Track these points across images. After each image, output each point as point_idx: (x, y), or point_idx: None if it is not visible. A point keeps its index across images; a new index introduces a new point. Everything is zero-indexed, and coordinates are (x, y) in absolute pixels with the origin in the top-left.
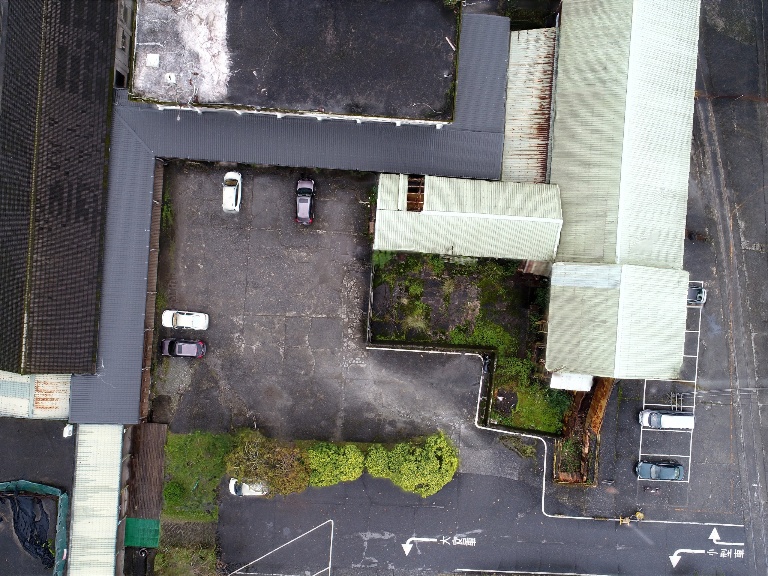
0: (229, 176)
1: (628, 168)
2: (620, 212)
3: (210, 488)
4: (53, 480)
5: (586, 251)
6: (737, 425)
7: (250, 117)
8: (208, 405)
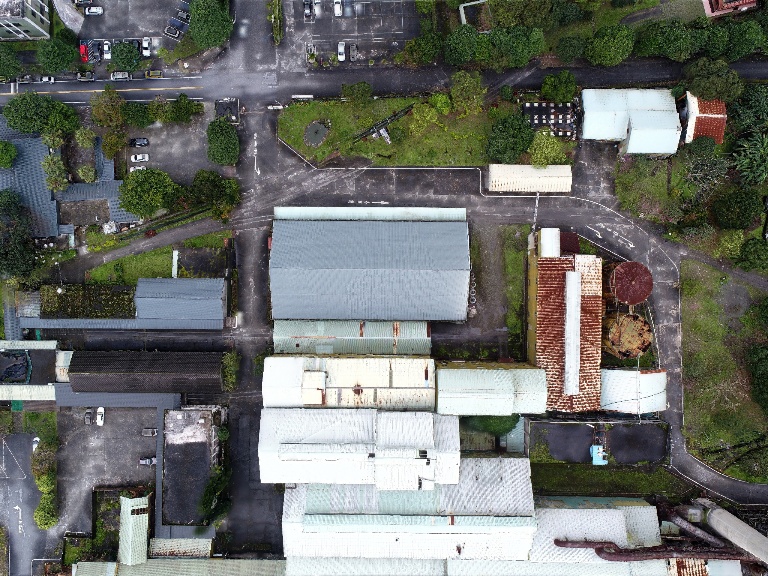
0: None
1: None
2: None
3: None
4: (33, 378)
5: (121, 574)
6: None
7: None
8: (69, 426)
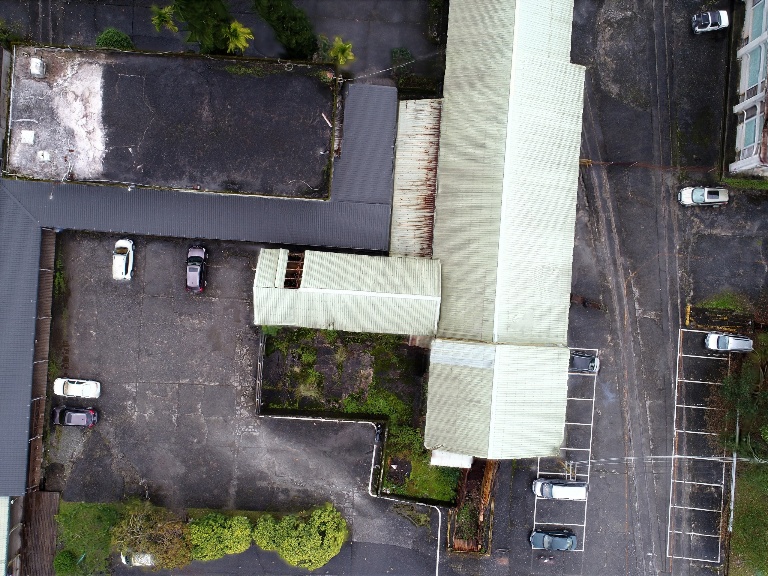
0: (120, 244)
1: (506, 245)
2: (497, 290)
3: (102, 557)
4: None
5: (466, 328)
6: (632, 494)
7: None
8: (101, 473)
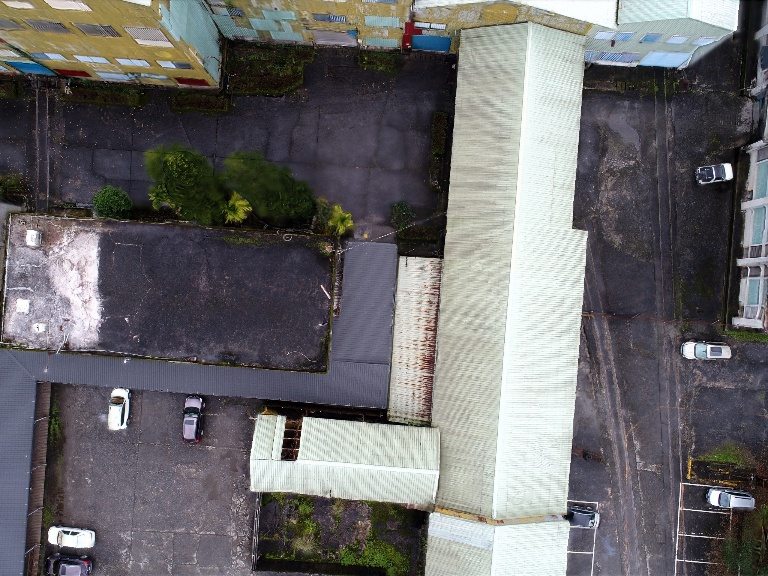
0: (116, 393)
1: (506, 419)
2: (497, 465)
3: None
4: None
5: (464, 500)
6: None
7: None
8: None
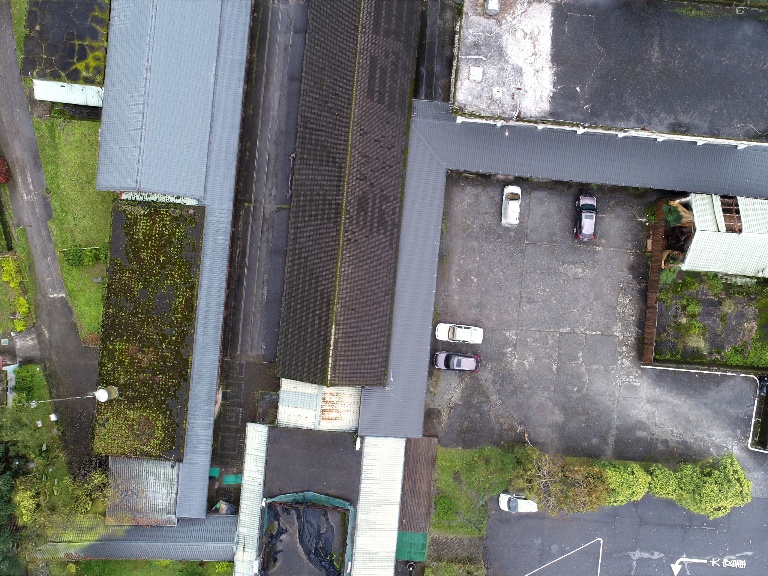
0: (510, 190)
1: None
2: None
3: None
4: (339, 492)
5: None
6: None
7: (548, 132)
8: (478, 419)
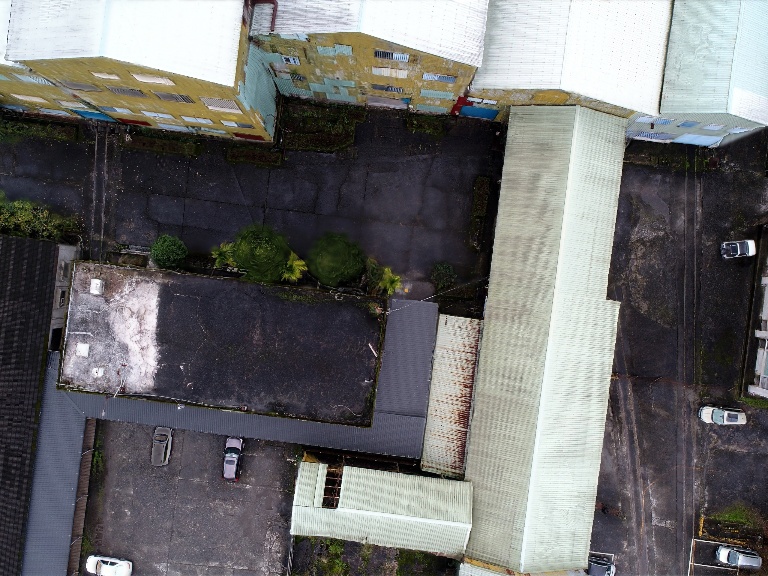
0: (160, 431)
1: (537, 478)
2: (527, 521)
3: None
4: None
5: (493, 552)
6: None
7: None
8: None
